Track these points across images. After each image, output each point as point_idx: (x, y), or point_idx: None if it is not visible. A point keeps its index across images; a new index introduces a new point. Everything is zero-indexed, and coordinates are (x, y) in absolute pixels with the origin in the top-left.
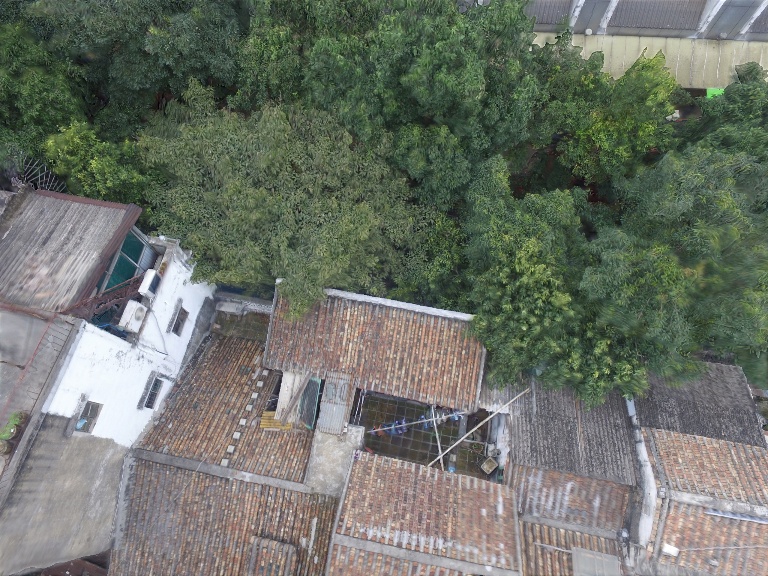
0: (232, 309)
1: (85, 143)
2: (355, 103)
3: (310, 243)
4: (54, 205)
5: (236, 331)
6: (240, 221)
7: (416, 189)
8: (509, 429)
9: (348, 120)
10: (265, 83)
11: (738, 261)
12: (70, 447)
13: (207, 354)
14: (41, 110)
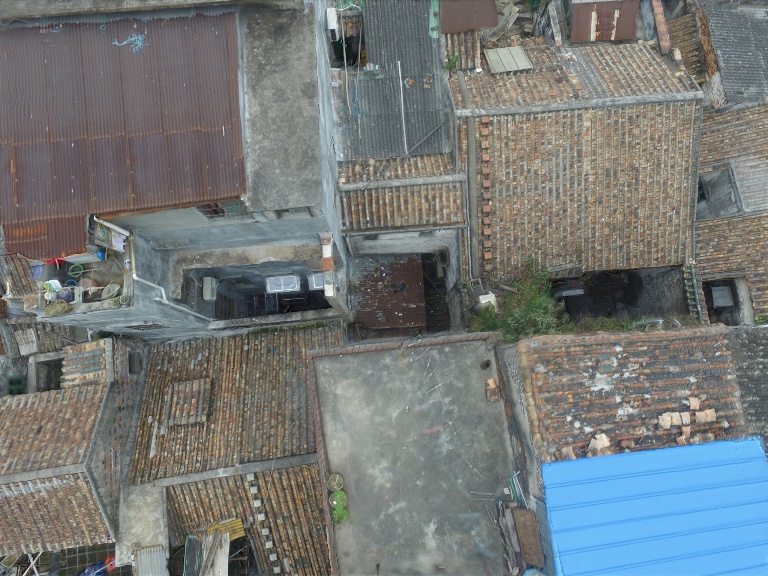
0: None
1: None
2: None
3: None
4: None
5: None
6: None
7: None
8: None
9: None
10: None
11: None
12: None
13: None
14: None
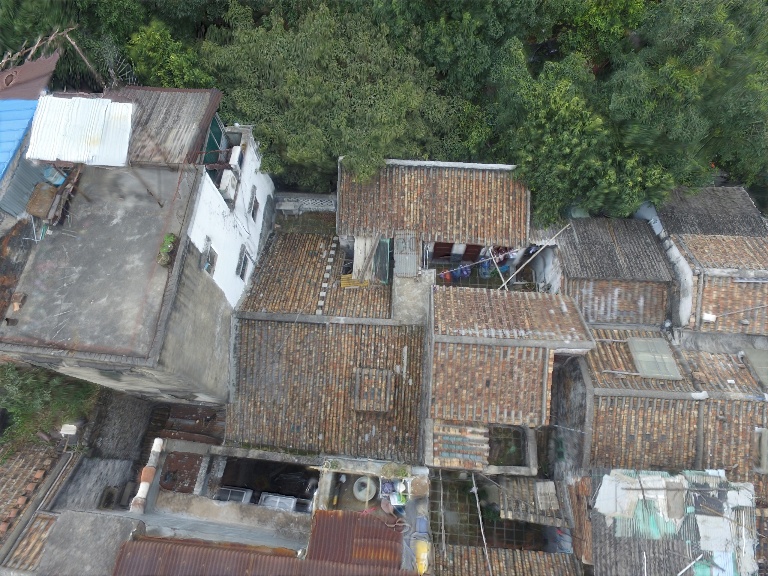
0: (291, 207)
1: (163, 41)
2: (386, 0)
3: (366, 120)
4: (145, 95)
5: (295, 228)
6: (301, 108)
7: (442, 82)
8: (558, 257)
9: (380, 18)
10: (296, 1)
11: (736, 66)
12: (203, 281)
13: (275, 246)
14: (117, 19)
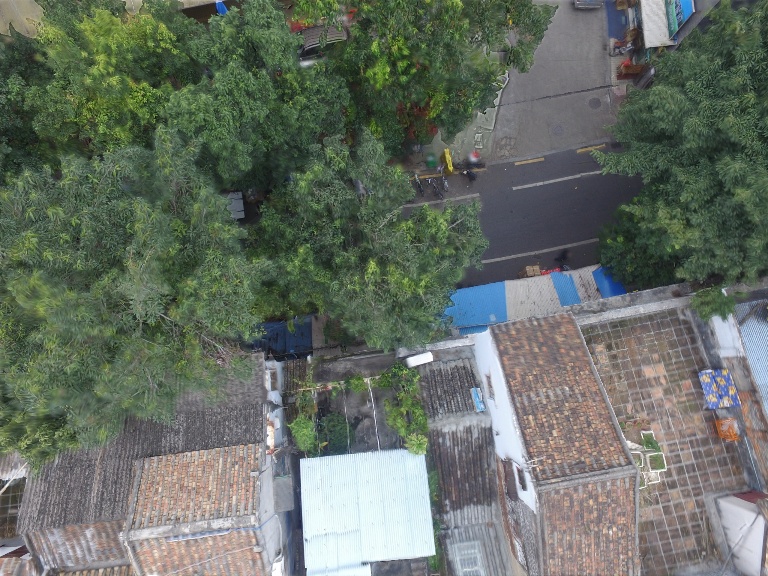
0: None
1: None
2: None
3: None
4: None
5: None
6: None
7: None
8: None
9: None
10: None
11: None
12: None
13: None
14: None
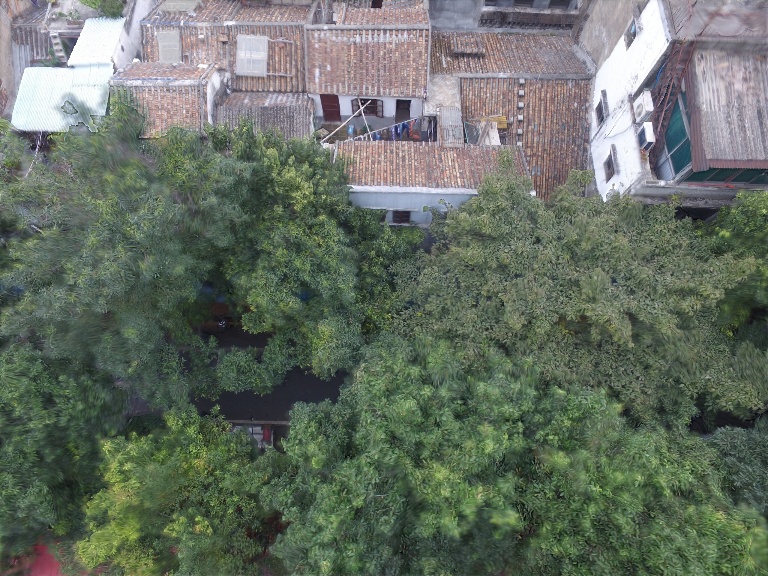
0: None
1: None
2: None
3: None
4: None
5: None
6: None
7: None
8: (310, 135)
9: None
10: None
11: (112, 171)
12: None
13: None
14: None
